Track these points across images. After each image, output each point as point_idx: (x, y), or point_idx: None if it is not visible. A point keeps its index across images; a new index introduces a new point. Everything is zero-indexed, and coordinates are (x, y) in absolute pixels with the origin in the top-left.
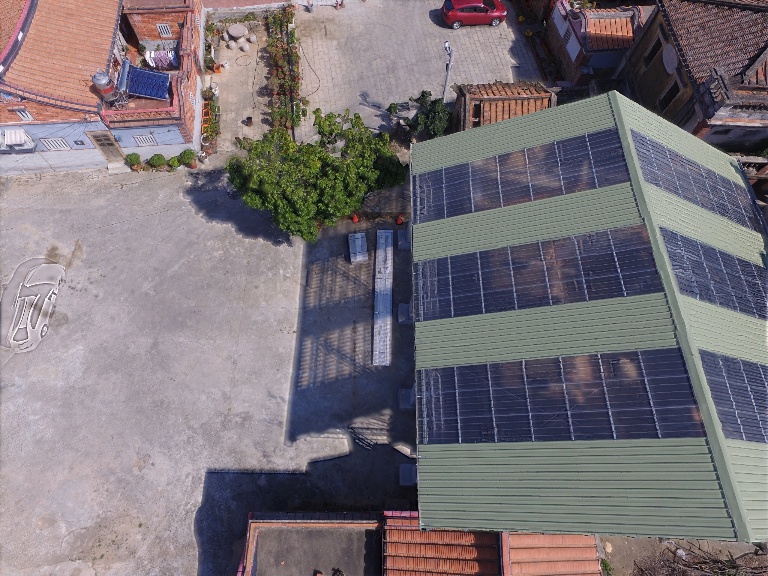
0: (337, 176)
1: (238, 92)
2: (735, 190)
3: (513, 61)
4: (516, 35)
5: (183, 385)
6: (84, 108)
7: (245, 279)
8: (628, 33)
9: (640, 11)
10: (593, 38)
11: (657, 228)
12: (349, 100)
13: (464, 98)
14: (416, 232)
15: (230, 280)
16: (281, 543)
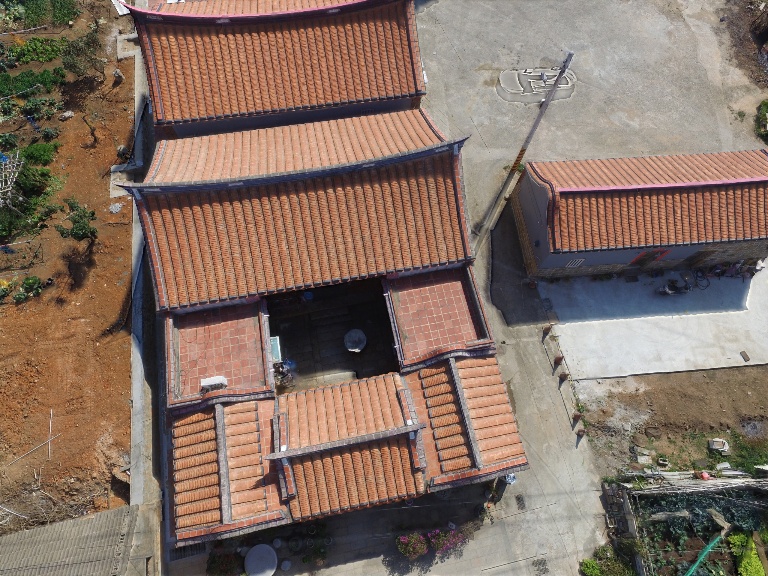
0: None
1: None
2: None
3: None
4: None
5: None
6: None
7: None
8: None
9: None
10: None
11: None
12: None
13: None
14: None
15: None
16: None
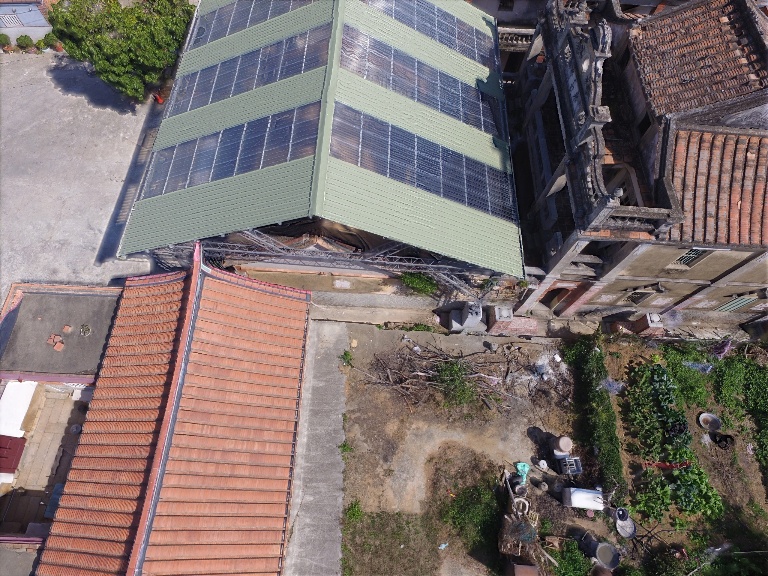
0: (144, 28)
1: None
2: (475, 34)
3: None
4: None
5: (14, 218)
6: None
7: (88, 139)
8: None
9: None
10: None
11: (340, 23)
12: None
13: None
14: (184, 58)
15: (74, 140)
16: (41, 305)
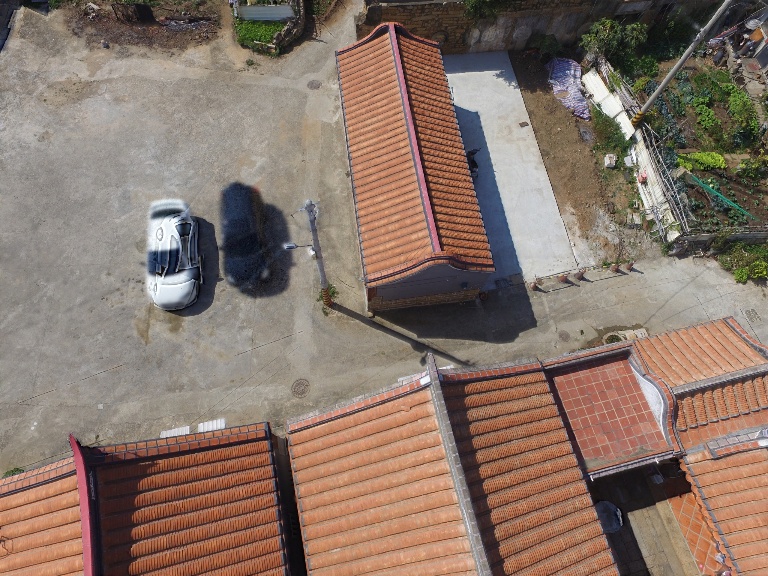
0: None
1: None
2: None
3: None
4: None
5: (5, 193)
6: (7, 480)
7: None
8: None
9: None
10: None
11: None
12: None
13: None
14: None
15: None
16: None
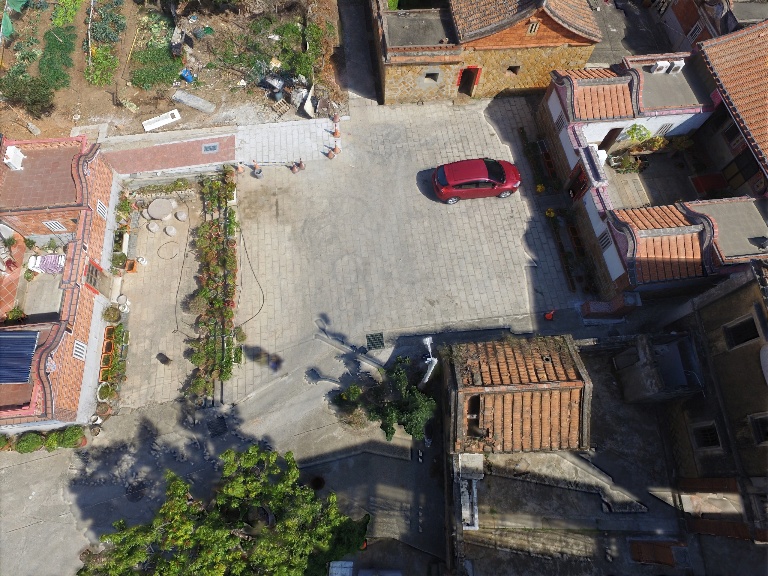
0: None
1: (156, 304)
2: None
3: (528, 257)
4: (533, 212)
5: None
6: None
7: None
8: (694, 254)
9: (713, 228)
10: (644, 265)
11: None
12: (301, 330)
13: (455, 393)
14: None
15: None
16: None
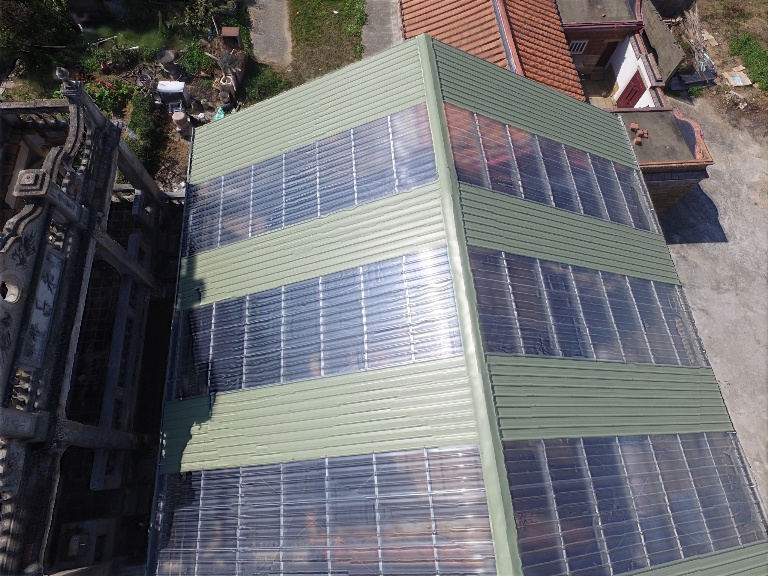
0: None
1: None
2: (196, 567)
3: None
4: None
5: None
6: None
7: None
8: None
9: None
10: None
11: (469, 342)
12: None
13: None
14: (727, 417)
15: None
16: (676, 158)
